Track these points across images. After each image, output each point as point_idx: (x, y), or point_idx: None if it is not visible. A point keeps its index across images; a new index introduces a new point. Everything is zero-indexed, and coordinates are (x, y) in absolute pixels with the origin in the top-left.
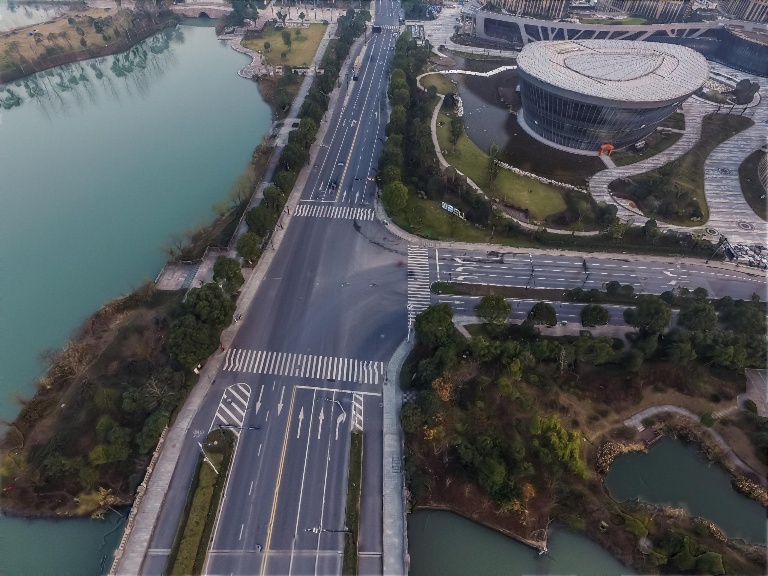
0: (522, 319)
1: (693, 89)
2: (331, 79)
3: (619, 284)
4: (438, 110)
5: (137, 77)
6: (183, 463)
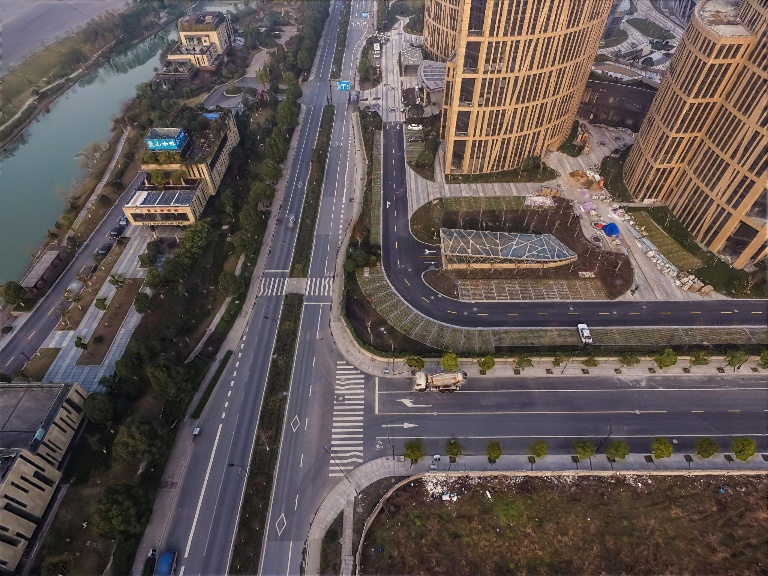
0: (334, 0)
1: None
2: None
3: (348, 4)
4: None
5: None
6: None
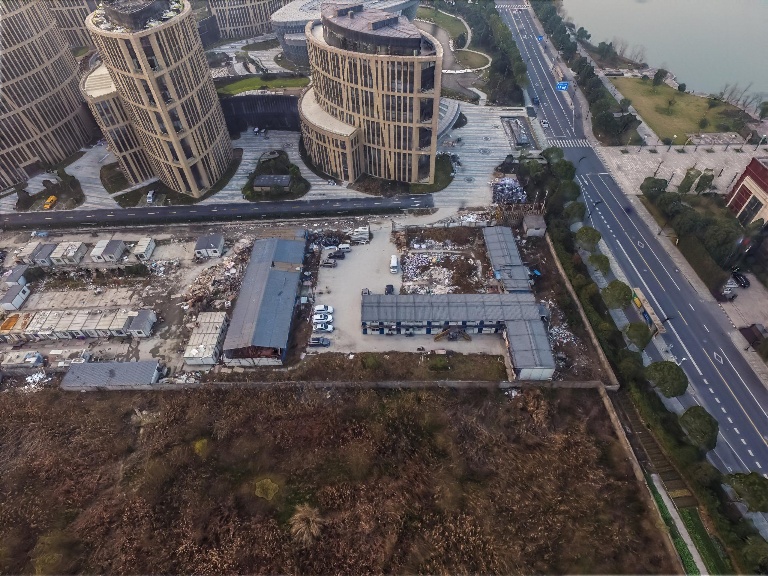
0: None
1: None
2: None
3: None
4: (468, 40)
5: None
6: None
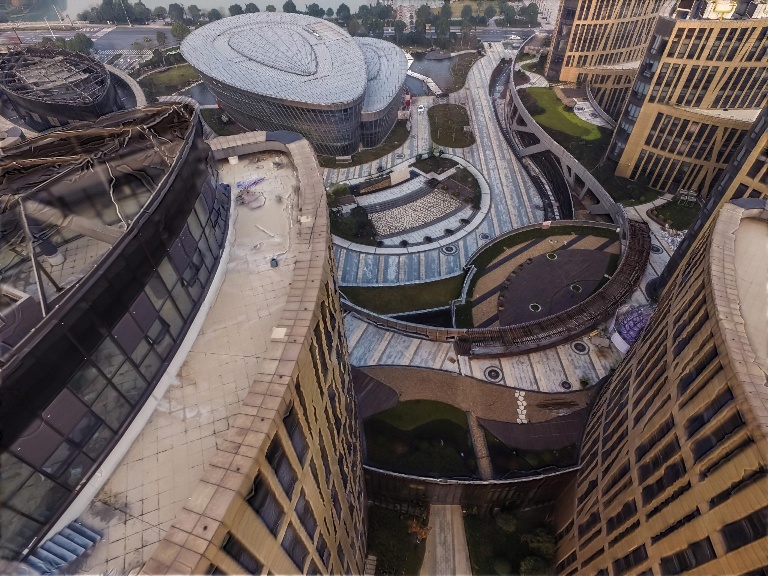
0: None
1: (200, 69)
2: (344, 9)
3: None
4: None
5: (436, 4)
6: (74, 26)
